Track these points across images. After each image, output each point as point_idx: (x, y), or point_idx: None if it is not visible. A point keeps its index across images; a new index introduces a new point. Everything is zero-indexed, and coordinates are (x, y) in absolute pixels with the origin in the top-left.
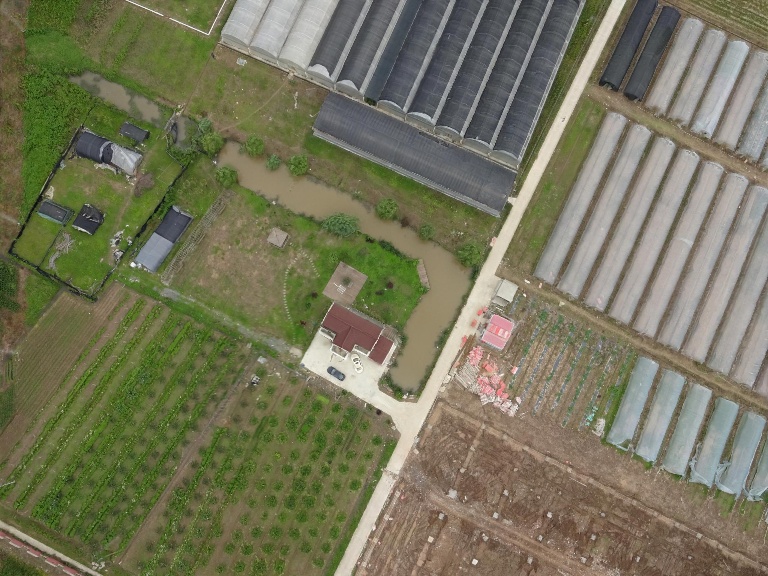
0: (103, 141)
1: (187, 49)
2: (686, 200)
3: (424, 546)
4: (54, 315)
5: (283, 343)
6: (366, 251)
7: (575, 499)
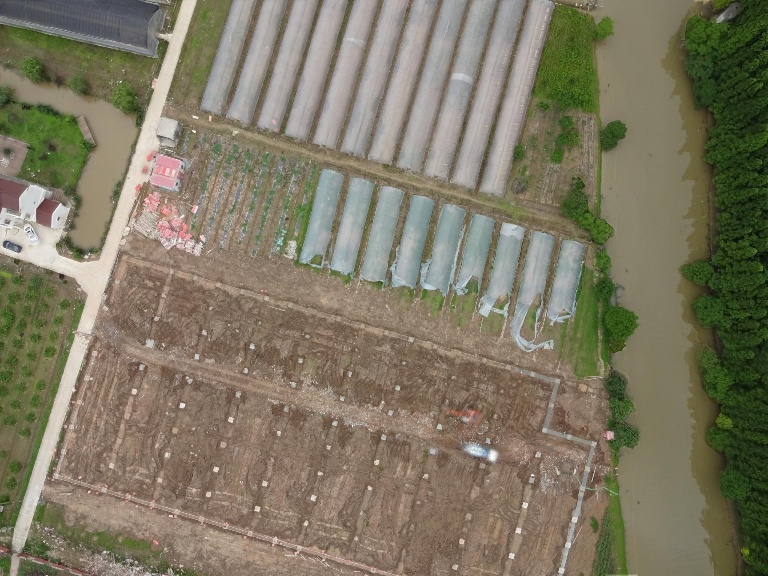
0: None
1: None
2: None
3: (129, 399)
4: None
5: None
6: None
7: (275, 326)
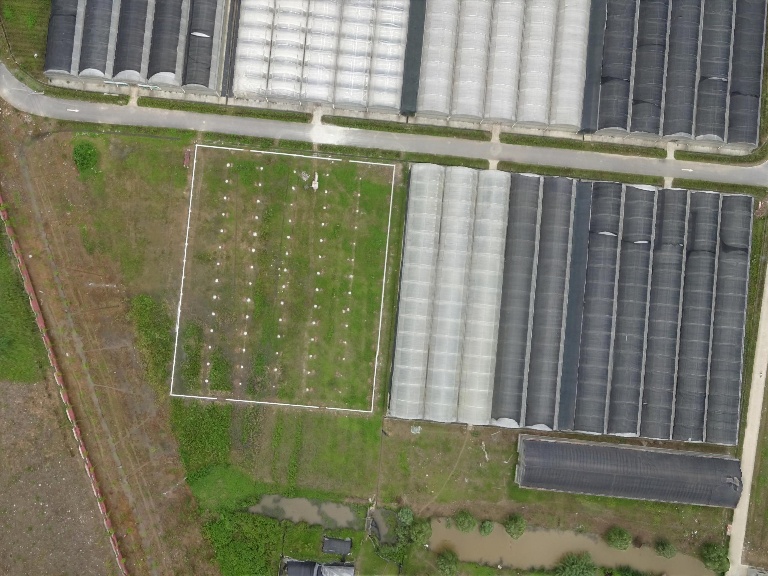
0: (311, 569)
1: (356, 435)
2: None
3: None
4: None
5: None
6: None
7: None
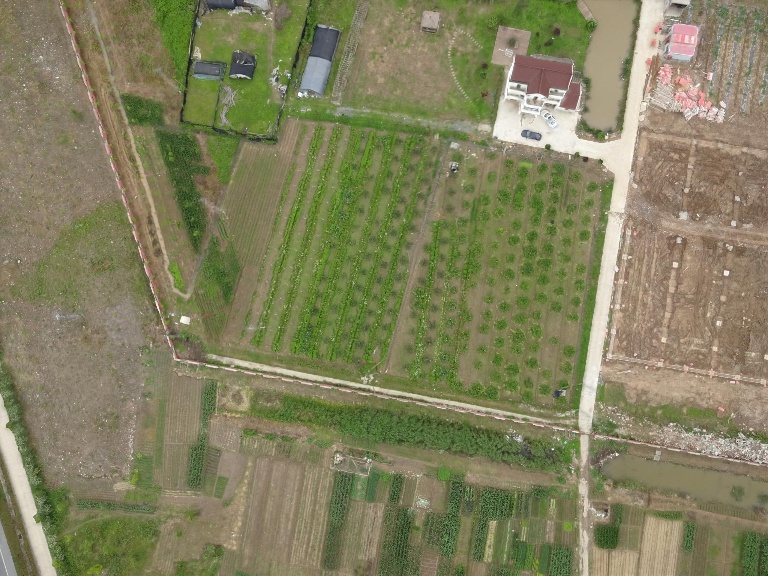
0: None
1: None
2: None
3: (671, 273)
4: (243, 167)
5: (469, 124)
6: None
7: None
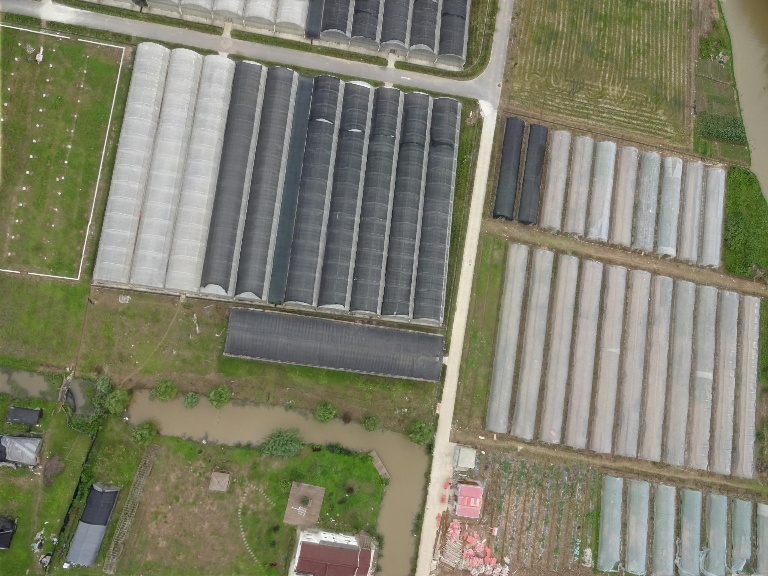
0: None
1: (58, 302)
2: (602, 308)
3: None
4: None
5: None
6: (316, 463)
7: None
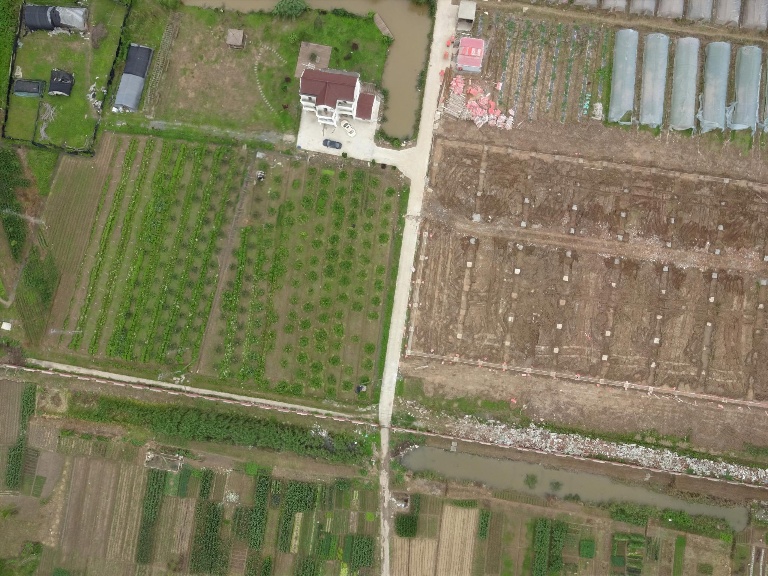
0: (47, 7)
1: None
2: None
3: (465, 272)
4: (62, 179)
5: (274, 134)
6: (322, 23)
7: (594, 185)
